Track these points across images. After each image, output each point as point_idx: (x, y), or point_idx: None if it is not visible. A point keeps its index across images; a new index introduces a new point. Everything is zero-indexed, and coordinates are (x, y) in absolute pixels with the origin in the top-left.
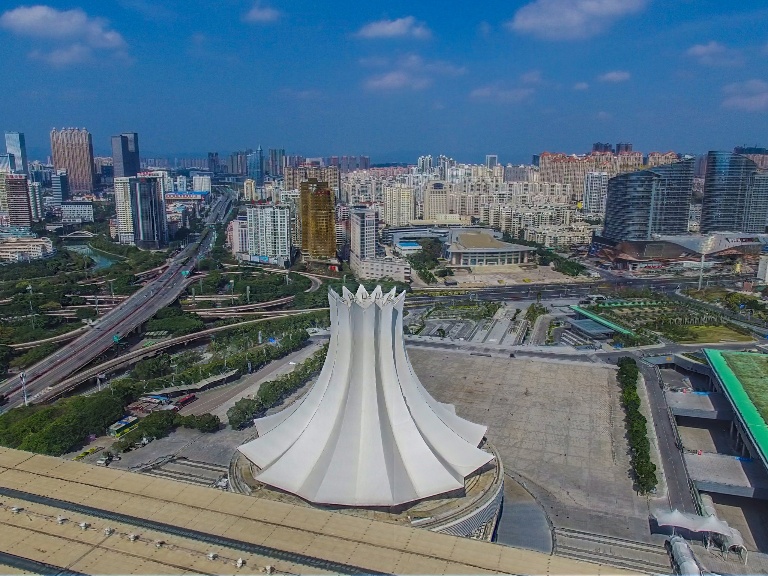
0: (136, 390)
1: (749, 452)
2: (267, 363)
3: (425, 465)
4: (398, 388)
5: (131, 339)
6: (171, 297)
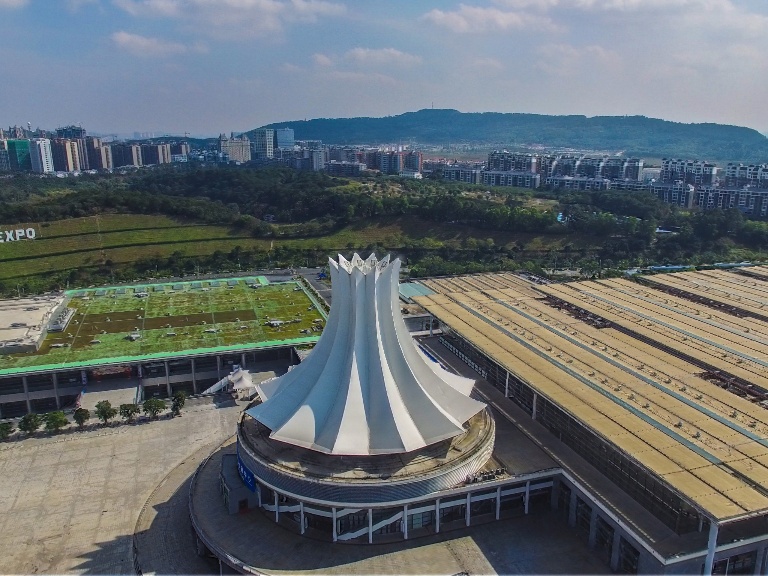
0: None
1: (52, 397)
2: None
3: None
4: None
5: None
6: None
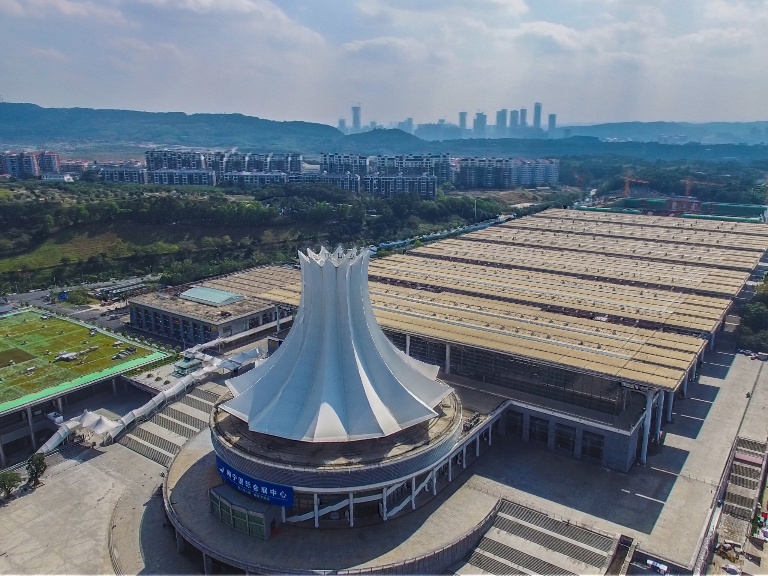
0: None
1: None
2: None
3: None
4: None
5: None
6: None
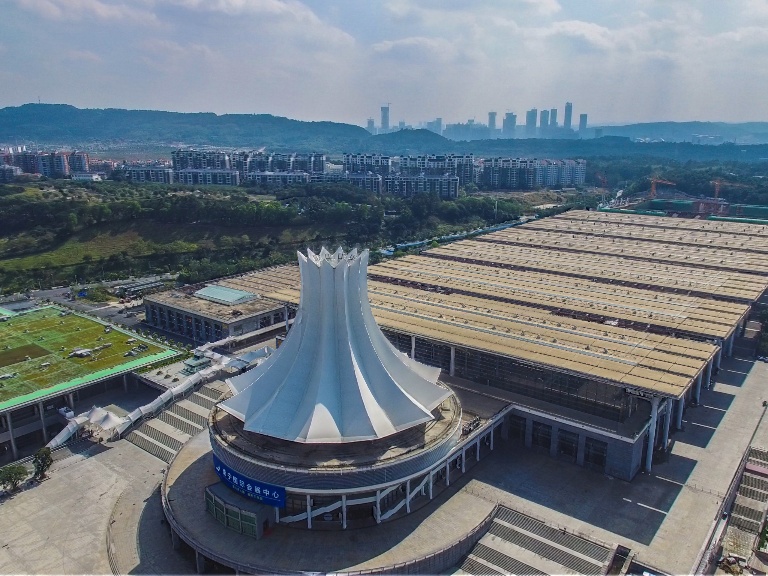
0: None
1: None
2: None
3: None
4: None
5: None
6: None
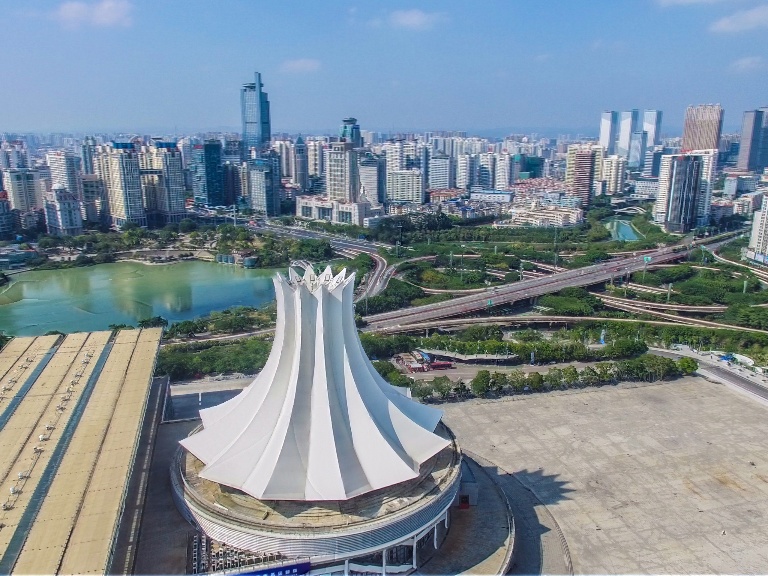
0: (413, 343)
1: None
2: (565, 361)
3: (269, 463)
4: (296, 379)
5: (522, 308)
6: (597, 279)
